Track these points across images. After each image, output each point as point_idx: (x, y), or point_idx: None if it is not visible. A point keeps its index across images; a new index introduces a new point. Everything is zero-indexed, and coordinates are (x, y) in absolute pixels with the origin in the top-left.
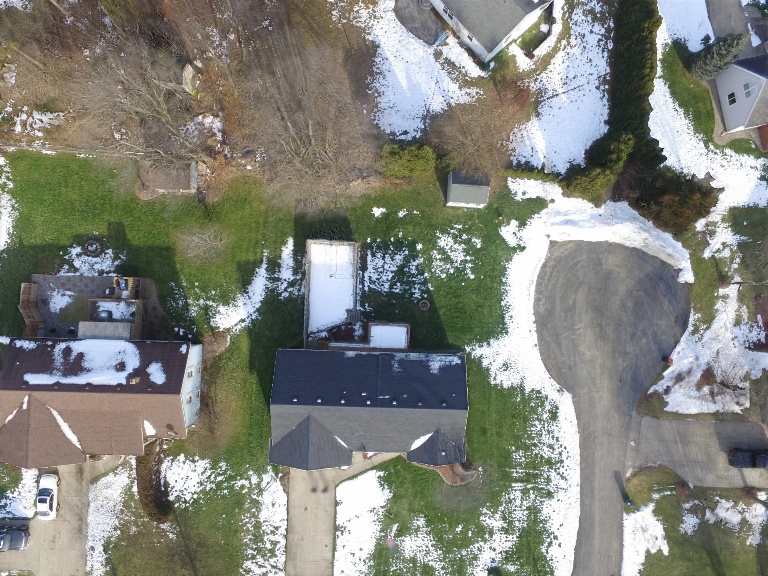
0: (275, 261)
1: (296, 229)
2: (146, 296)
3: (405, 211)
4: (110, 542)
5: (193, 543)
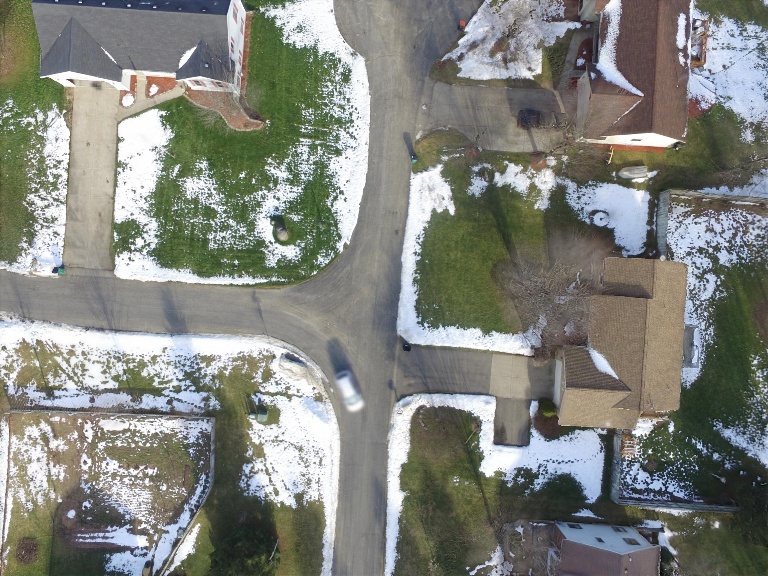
0: None
1: None
2: None
3: None
4: None
5: None
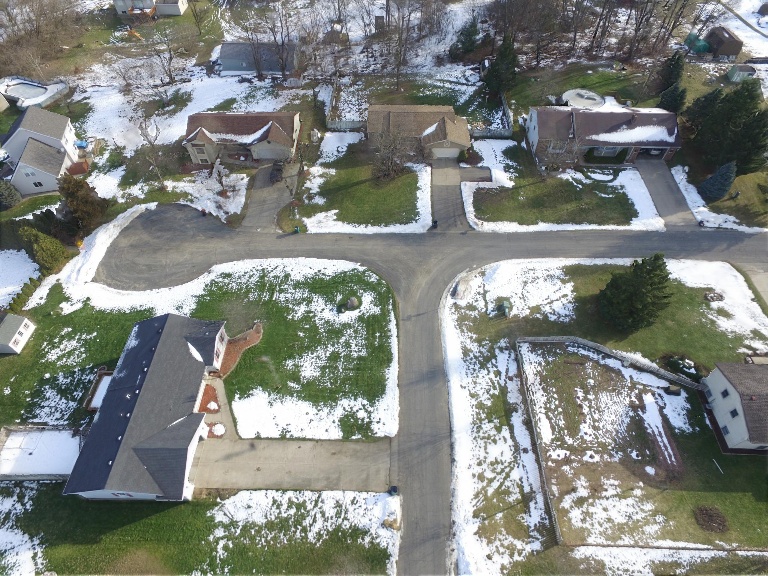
0: None
1: None
2: None
3: (7, 388)
4: None
5: None
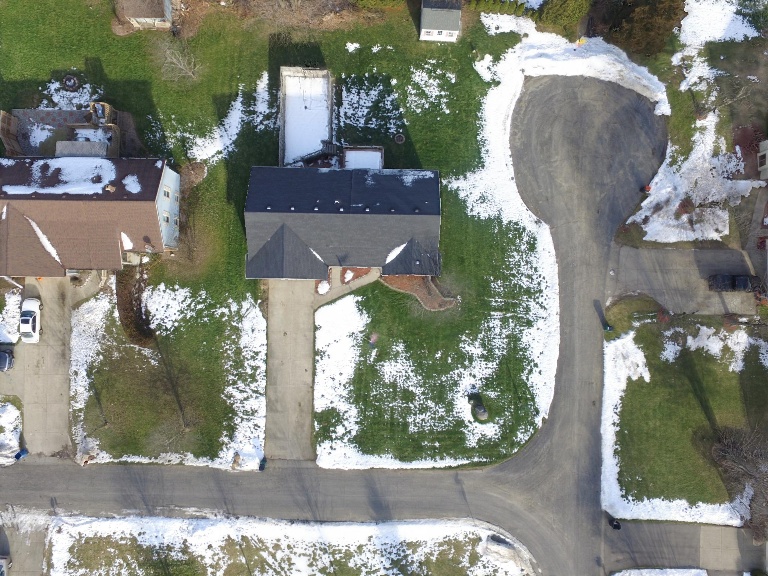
0: (250, 94)
1: (270, 63)
2: (124, 129)
3: (379, 46)
4: (93, 367)
5: (175, 369)
